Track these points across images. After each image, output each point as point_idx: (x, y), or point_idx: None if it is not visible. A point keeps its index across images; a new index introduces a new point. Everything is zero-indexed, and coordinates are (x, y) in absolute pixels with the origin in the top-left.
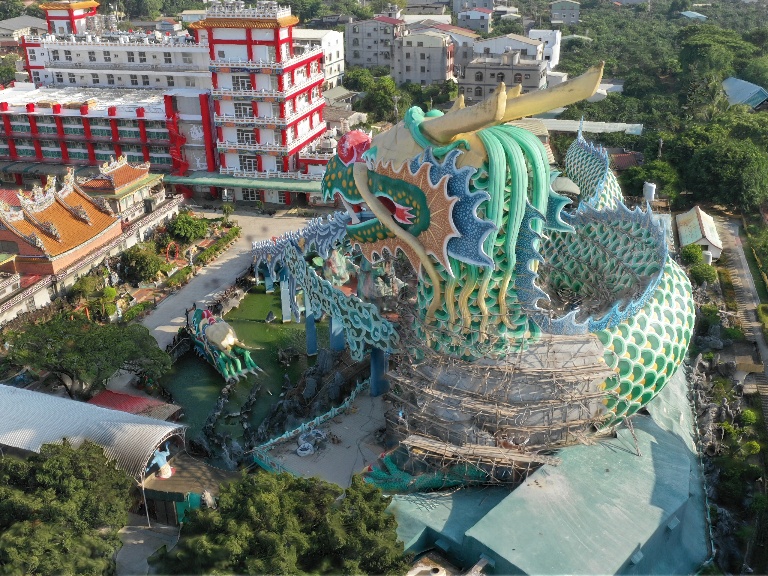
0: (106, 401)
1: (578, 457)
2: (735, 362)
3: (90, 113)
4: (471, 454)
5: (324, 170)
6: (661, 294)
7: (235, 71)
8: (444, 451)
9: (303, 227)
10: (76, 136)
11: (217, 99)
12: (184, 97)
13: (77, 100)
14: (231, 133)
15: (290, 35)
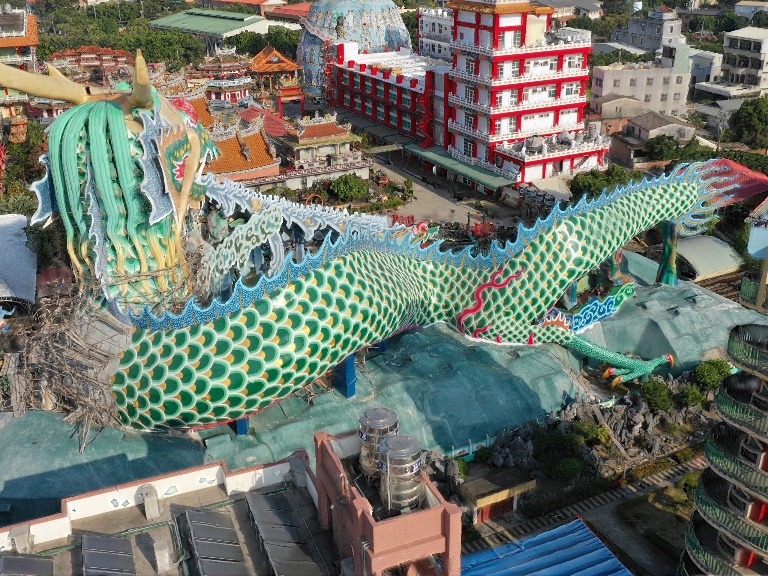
0: (54, 272)
1: (38, 422)
2: (468, 481)
3: (390, 78)
4: (8, 381)
5: (514, 168)
6: (224, 321)
7: (464, 54)
8: (5, 371)
9: (458, 217)
10: (378, 97)
11: (452, 79)
12: (439, 74)
13: (407, 67)
14: (461, 115)
15: (523, 23)
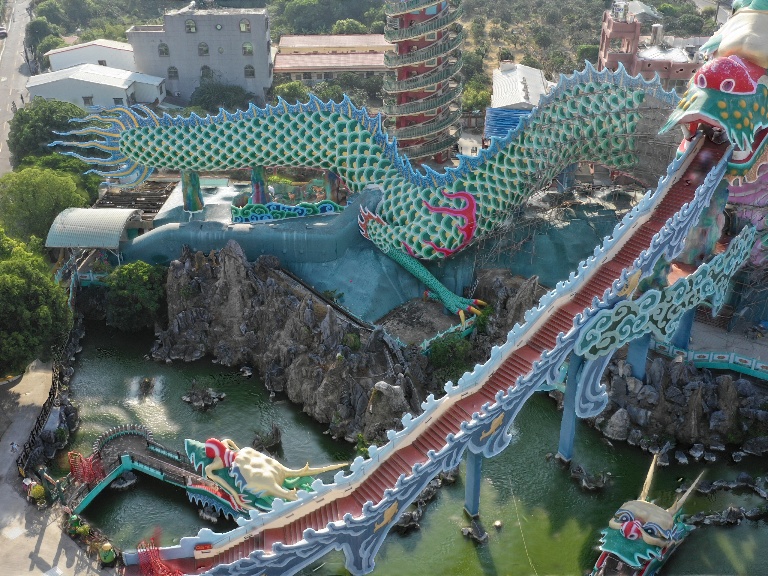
0: None
1: None
2: None
3: None
4: None
5: None
6: None
7: None
8: None
9: None
10: None
11: None
12: None
13: None
14: None
15: None
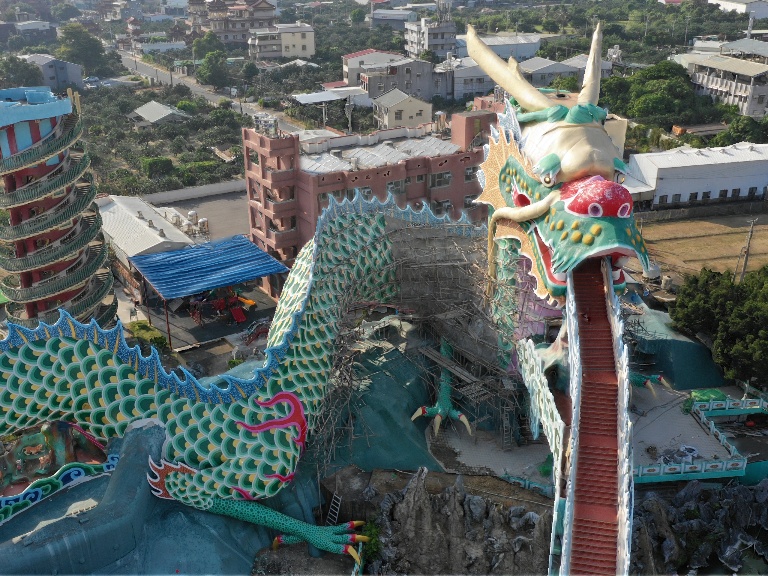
0: None
1: None
2: (229, 352)
3: None
4: None
5: None
6: None
7: None
8: None
9: None
10: None
11: None
12: None
13: None
14: None
15: None
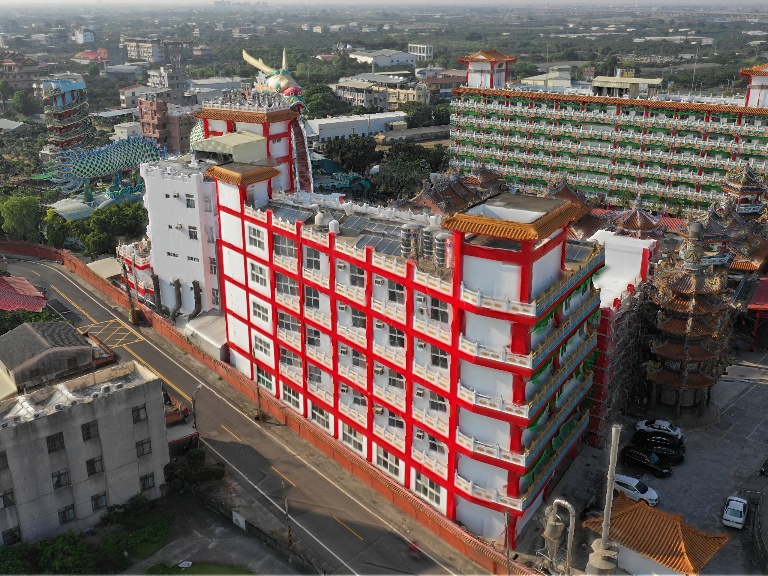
0: None
1: None
2: None
3: None
4: None
5: None
6: None
7: None
8: None
9: None
10: None
11: None
12: None
13: None
14: None
15: (208, 128)
